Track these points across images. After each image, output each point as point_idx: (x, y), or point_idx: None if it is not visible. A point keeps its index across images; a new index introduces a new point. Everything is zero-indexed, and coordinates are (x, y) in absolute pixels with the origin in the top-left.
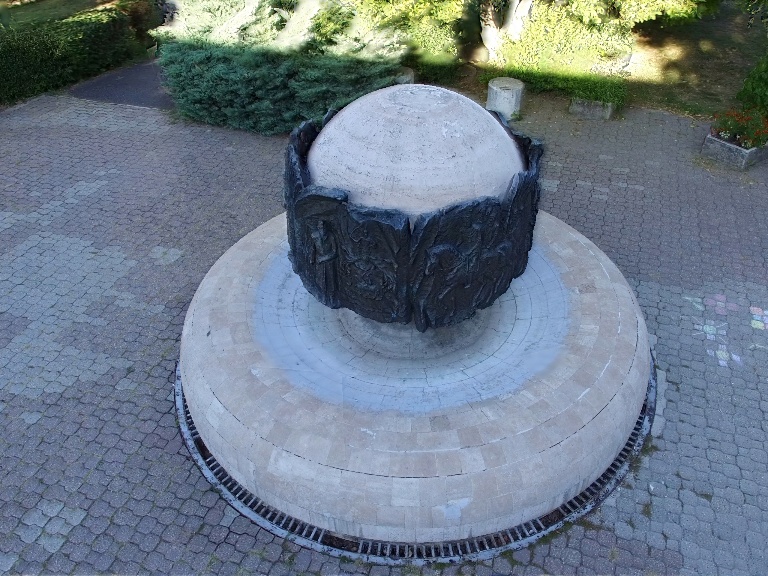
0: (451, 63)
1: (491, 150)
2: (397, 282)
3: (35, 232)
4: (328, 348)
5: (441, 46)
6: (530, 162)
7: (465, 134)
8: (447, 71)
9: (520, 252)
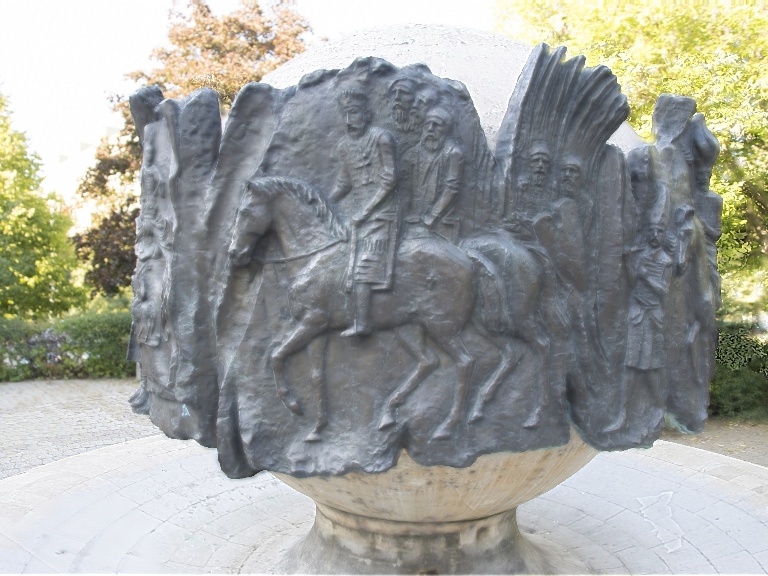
0: (766, 391)
1: (520, 62)
2: (175, 279)
3: (127, 436)
4: (167, 569)
5: (745, 360)
6: (657, 137)
7: (462, 32)
8: (759, 403)
9: (598, 344)
